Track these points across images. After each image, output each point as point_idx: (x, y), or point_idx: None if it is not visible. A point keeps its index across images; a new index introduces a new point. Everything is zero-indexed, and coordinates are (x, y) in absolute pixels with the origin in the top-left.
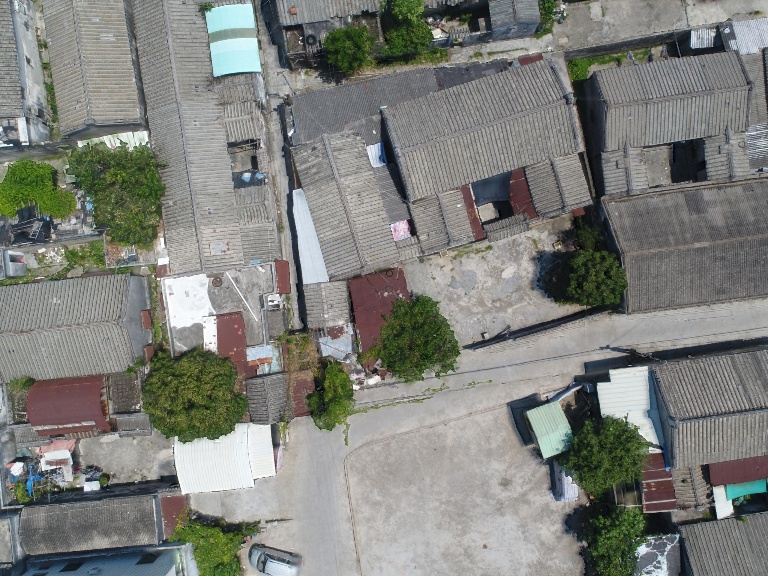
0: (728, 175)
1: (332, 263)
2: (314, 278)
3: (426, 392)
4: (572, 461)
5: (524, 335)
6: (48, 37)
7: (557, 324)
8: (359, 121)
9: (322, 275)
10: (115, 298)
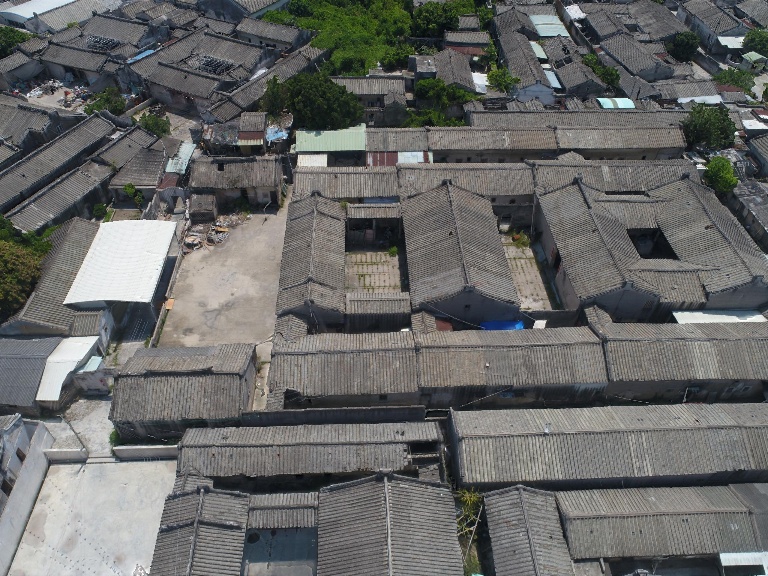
0: (634, 19)
1: (711, 92)
2: (720, 100)
3: (762, 67)
4: (767, 48)
5: (716, 63)
6: (634, 146)
7: (706, 60)
8: (642, 80)
9: (718, 97)
10: (767, 138)
